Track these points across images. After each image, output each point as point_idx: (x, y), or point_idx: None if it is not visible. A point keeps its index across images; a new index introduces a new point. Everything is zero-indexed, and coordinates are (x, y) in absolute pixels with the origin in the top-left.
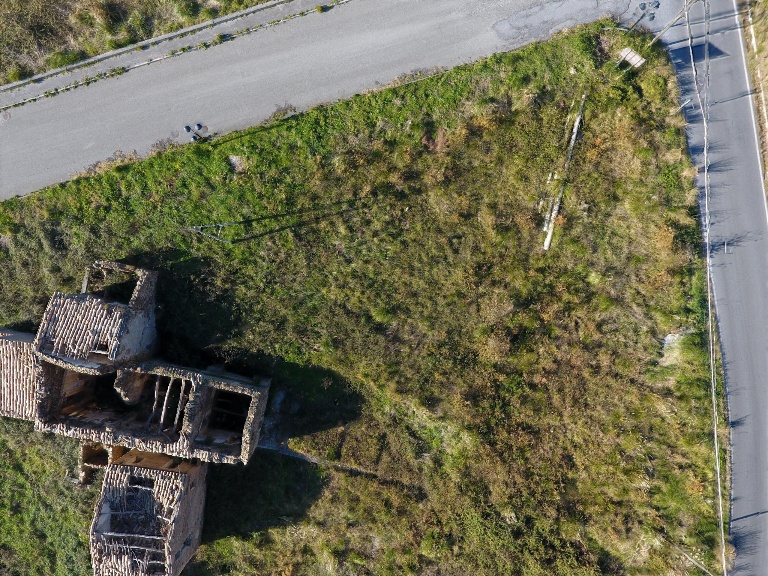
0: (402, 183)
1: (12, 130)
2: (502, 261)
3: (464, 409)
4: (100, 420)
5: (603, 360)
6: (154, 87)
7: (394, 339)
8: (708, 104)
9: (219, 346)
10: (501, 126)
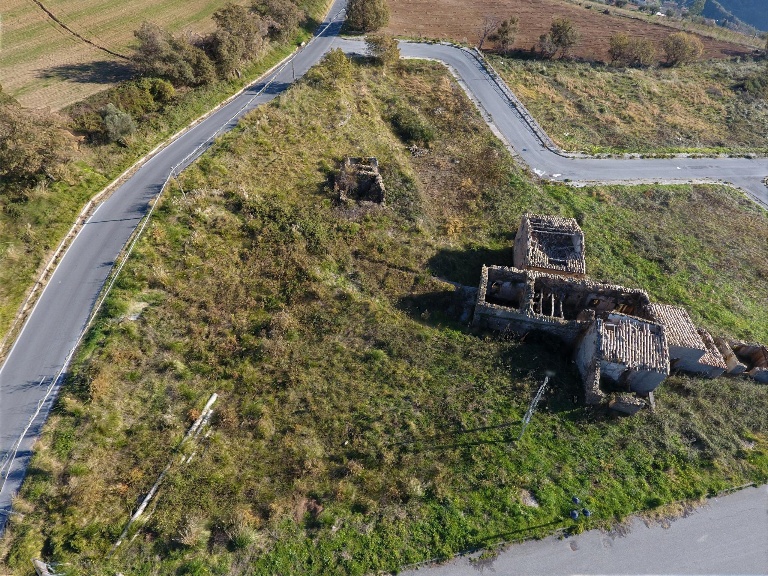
0: (349, 463)
1: None
2: (261, 388)
3: None
4: (601, 302)
5: (194, 311)
6: None
7: (368, 338)
8: (6, 458)
9: None
10: None
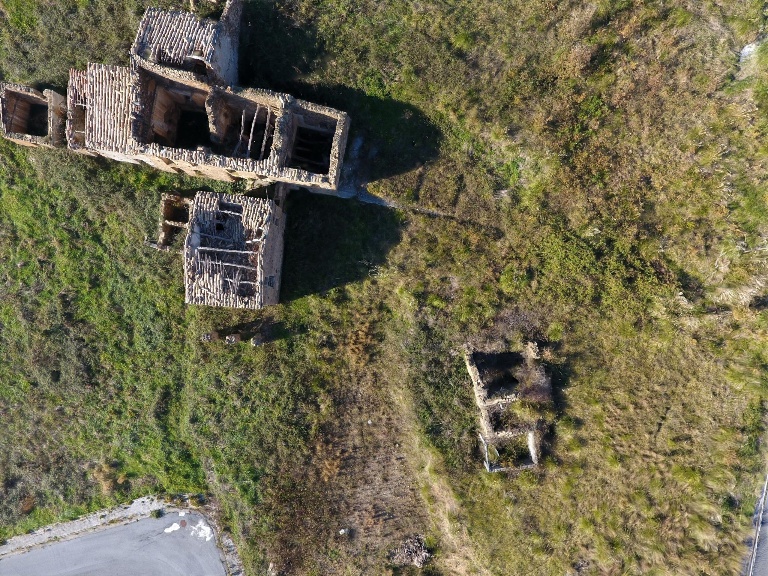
0: None
1: None
2: None
3: (543, 134)
4: None
5: (680, 79)
6: None
7: (474, 66)
8: None
9: (302, 79)
10: None
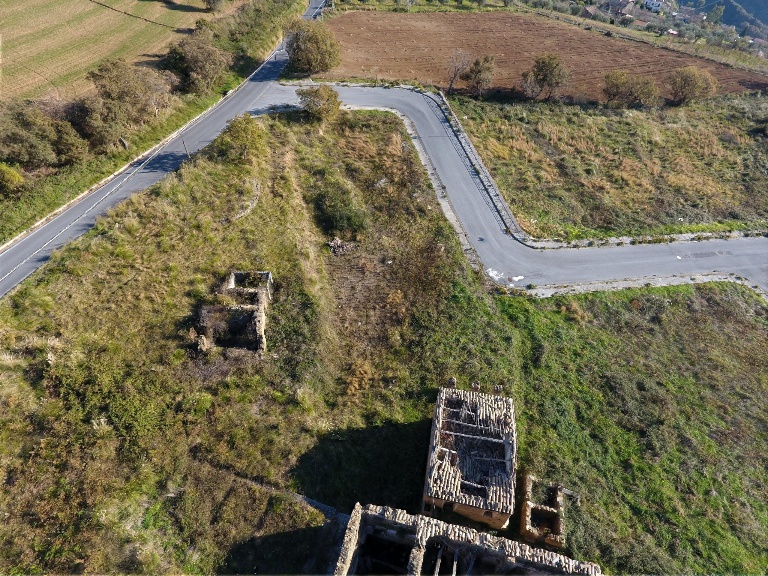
0: None
1: None
2: None
3: None
4: (533, 571)
5: None
6: None
7: None
8: None
9: None
10: None
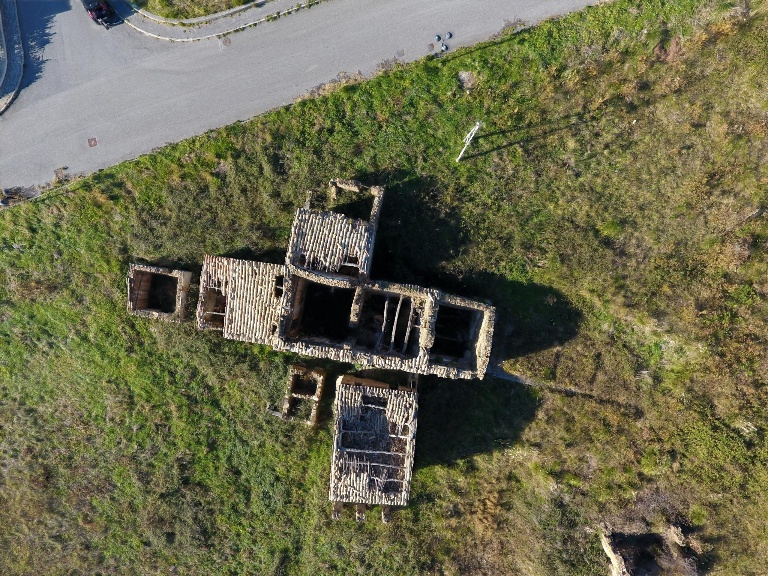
0: (634, 94)
1: (232, 55)
2: (732, 170)
3: (692, 322)
4: None
5: None
6: (378, 7)
7: (621, 253)
8: None
9: (443, 265)
10: (739, 32)
